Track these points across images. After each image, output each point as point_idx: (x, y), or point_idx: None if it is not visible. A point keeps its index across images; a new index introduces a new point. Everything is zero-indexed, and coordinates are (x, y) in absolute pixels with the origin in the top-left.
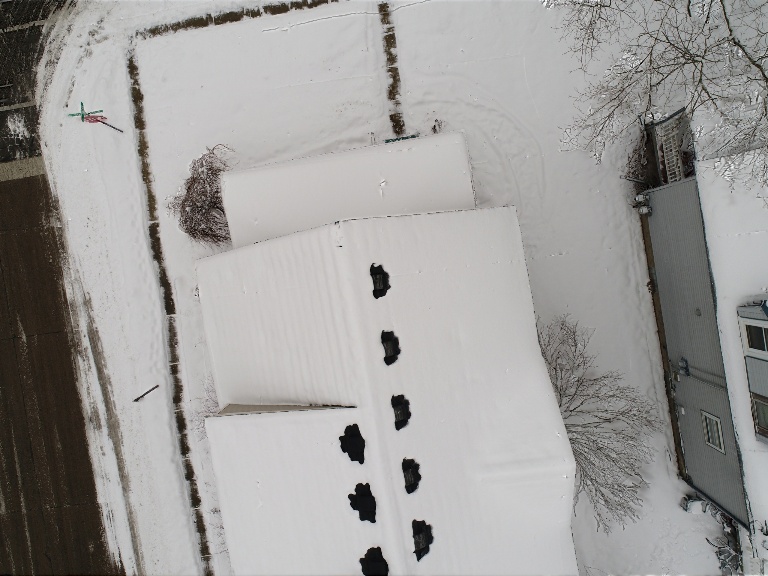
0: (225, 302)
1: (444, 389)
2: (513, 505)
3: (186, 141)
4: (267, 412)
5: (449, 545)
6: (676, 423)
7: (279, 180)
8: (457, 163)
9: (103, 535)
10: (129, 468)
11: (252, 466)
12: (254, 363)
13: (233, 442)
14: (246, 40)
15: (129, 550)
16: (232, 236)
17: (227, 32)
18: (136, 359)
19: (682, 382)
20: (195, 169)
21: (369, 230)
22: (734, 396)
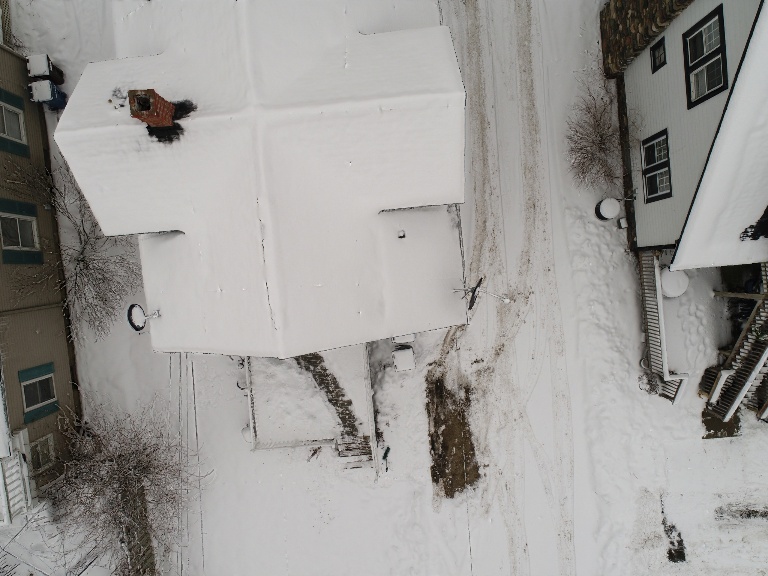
0: None
1: None
2: None
3: None
4: None
5: None
6: None
7: None
8: None
9: None
10: None
11: None
12: None
13: None
14: None
15: None
16: None
17: None
18: None
19: None
20: None
21: None
22: None
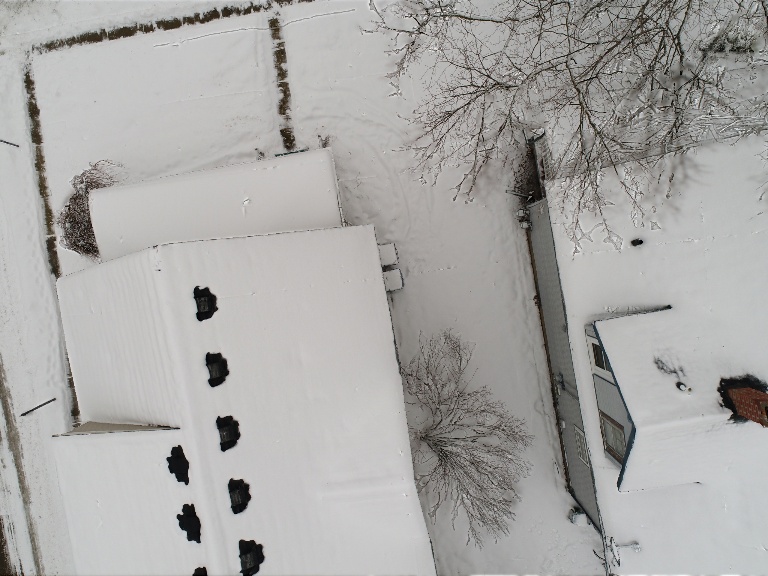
0: (79, 321)
1: (280, 409)
2: (360, 522)
3: (80, 156)
4: (106, 432)
5: (283, 564)
6: (562, 436)
7: (145, 198)
8: (321, 181)
9: (4, 547)
10: (29, 480)
11: (92, 485)
12: (103, 382)
13: (75, 462)
14: (138, 55)
15: (30, 562)
16: (100, 254)
17: (119, 47)
18: (33, 372)
19: (561, 396)
20: (76, 185)
21: (192, 253)
22: (585, 413)
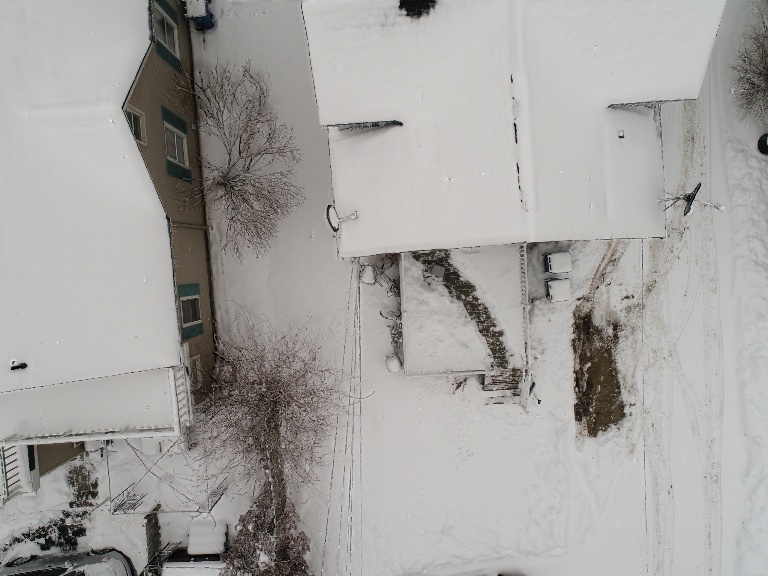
0: None
1: None
2: (74, 160)
3: None
4: None
5: None
6: None
7: None
8: None
9: None
10: None
11: None
12: None
13: None
14: None
15: None
16: None
17: None
18: None
19: None
20: None
21: None
22: None
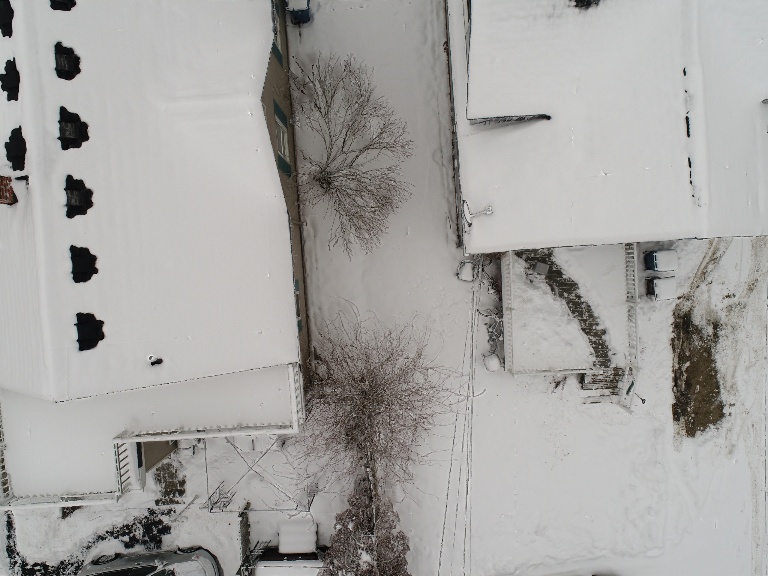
0: None
1: (127, 1)
2: (206, 153)
3: None
4: None
5: (110, 153)
6: None
7: None
8: None
9: None
10: None
11: None
12: None
13: None
14: None
15: None
16: None
17: None
18: None
19: None
20: None
21: None
22: (455, 81)
